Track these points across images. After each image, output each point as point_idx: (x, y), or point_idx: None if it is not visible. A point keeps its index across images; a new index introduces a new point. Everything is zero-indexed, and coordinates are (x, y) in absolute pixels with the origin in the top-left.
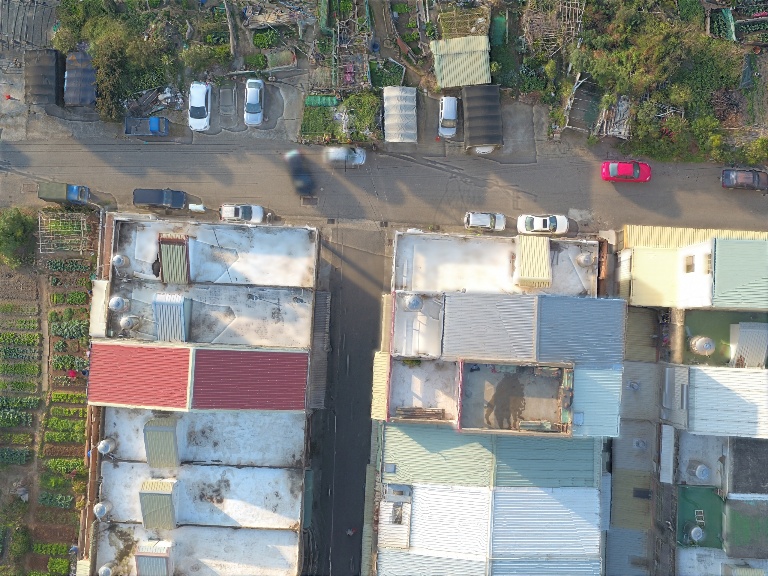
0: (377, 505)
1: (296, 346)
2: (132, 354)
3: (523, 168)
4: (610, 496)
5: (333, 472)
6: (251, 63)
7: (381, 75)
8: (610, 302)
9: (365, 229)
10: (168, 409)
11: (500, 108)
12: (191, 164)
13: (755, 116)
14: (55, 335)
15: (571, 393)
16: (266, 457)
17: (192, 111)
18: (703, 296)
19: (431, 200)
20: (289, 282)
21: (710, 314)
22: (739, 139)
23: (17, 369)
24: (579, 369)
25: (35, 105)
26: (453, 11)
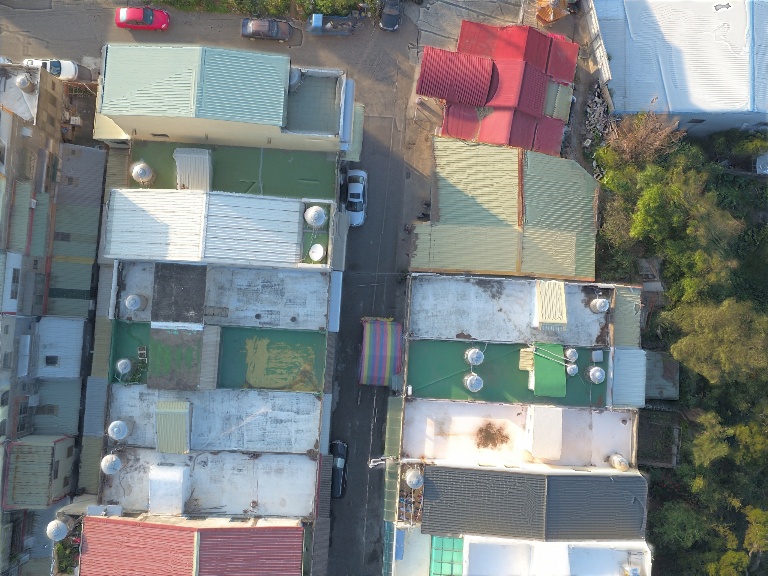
0: None
1: None
2: None
3: (36, 14)
4: (82, 342)
5: None
6: None
7: None
8: None
9: None
10: None
11: None
12: None
13: None
14: None
15: None
16: None
17: None
18: None
19: None
20: None
21: (167, 146)
22: None
23: None
24: None
25: None
26: None
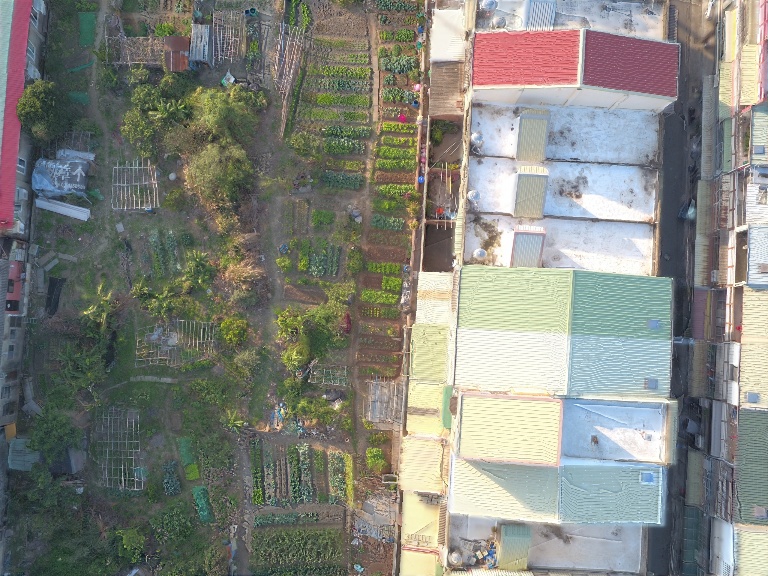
0: (725, 203)
1: None
2: (517, 40)
3: None
4: None
5: None
6: None
7: None
8: None
9: None
10: (559, 86)
11: None
12: None
13: None
14: (385, 69)
15: None
16: (622, 156)
17: None
18: None
19: None
20: None
21: None
22: None
23: (350, 100)
24: None
25: None
26: None
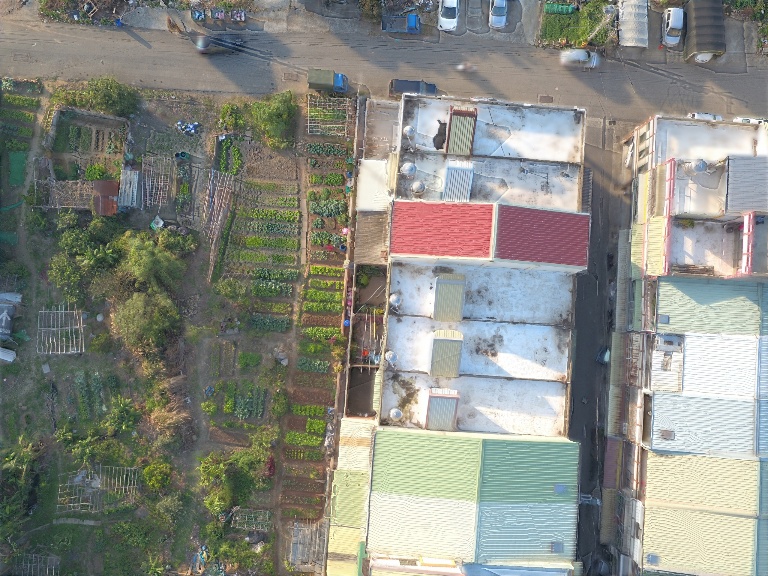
0: (635, 362)
1: None
2: (433, 210)
3: (735, 77)
4: None
5: None
6: None
7: None
8: None
9: (595, 126)
10: (471, 258)
11: (723, 19)
12: (438, 61)
13: None
14: (314, 213)
15: None
16: (536, 316)
17: (444, 11)
18: None
19: (654, 102)
20: (556, 159)
21: None
22: None
23: (278, 243)
24: None
25: (297, 1)
26: None
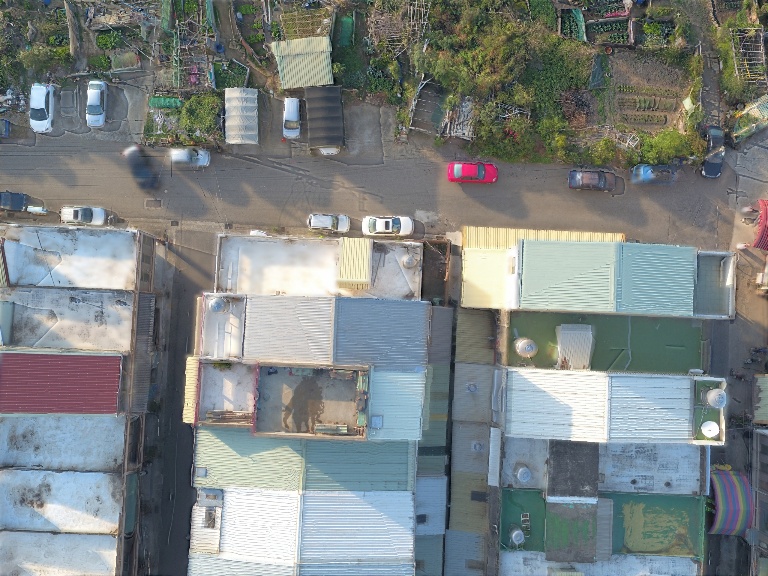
0: None
1: (119, 349)
2: None
3: (370, 169)
4: (446, 499)
5: (175, 476)
6: (94, 65)
7: (225, 76)
8: (412, 304)
9: (209, 231)
10: None
11: (341, 109)
12: (34, 166)
13: (606, 117)
14: None
15: (366, 396)
16: (87, 461)
17: (32, 113)
18: (516, 298)
19: (276, 202)
20: (113, 285)
21: (539, 316)
22: (588, 140)
23: None
24: (378, 372)
25: None
26: (295, 12)
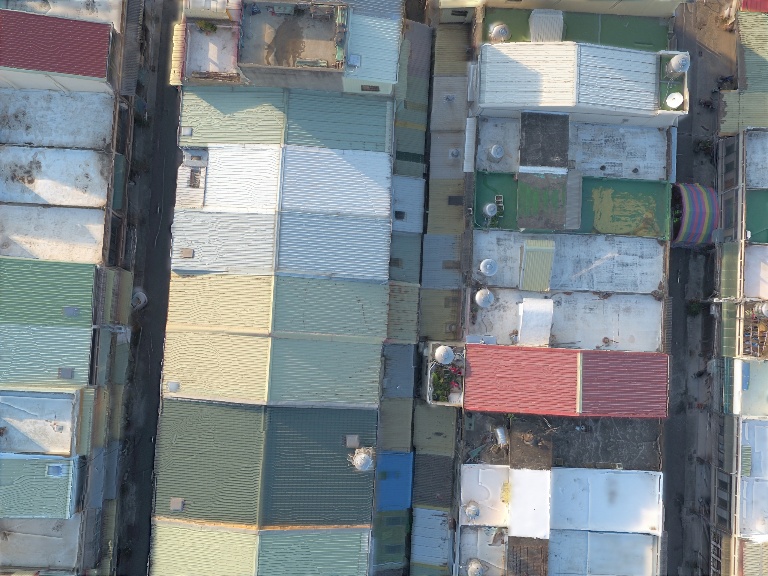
0: None
1: None
2: None
3: None
4: (424, 200)
5: (162, 190)
6: None
7: None
8: None
9: None
10: None
11: None
12: None
13: None
14: None
15: (345, 29)
16: (77, 140)
17: None
18: None
19: None
20: None
21: (513, 13)
22: None
23: None
24: (357, 14)
25: None
26: None
